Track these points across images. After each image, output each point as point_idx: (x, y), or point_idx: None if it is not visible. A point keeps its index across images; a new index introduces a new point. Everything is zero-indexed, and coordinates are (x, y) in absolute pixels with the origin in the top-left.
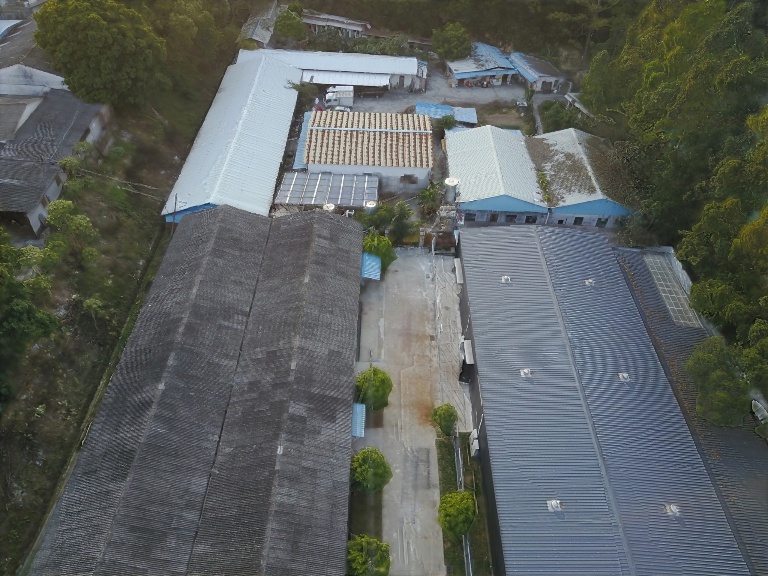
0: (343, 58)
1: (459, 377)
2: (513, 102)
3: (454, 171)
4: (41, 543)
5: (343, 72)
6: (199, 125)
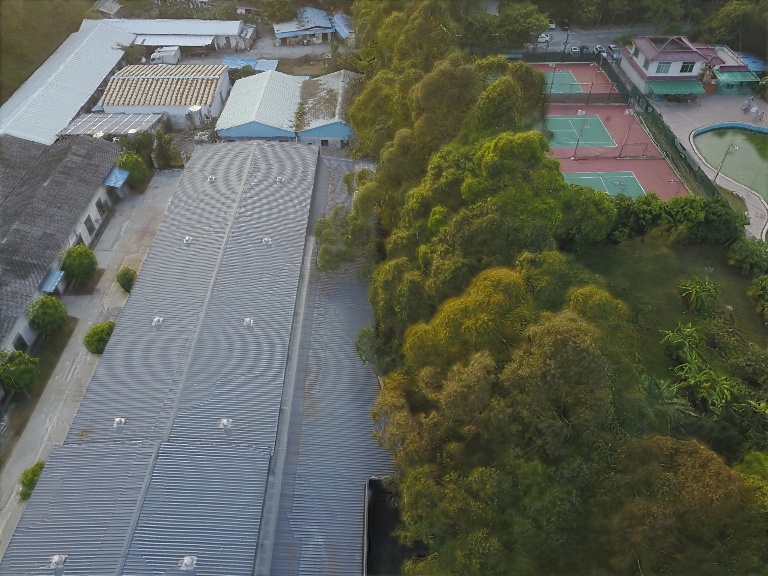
0: (174, 23)
1: None
2: (322, 56)
3: (227, 107)
4: None
5: (172, 35)
6: None
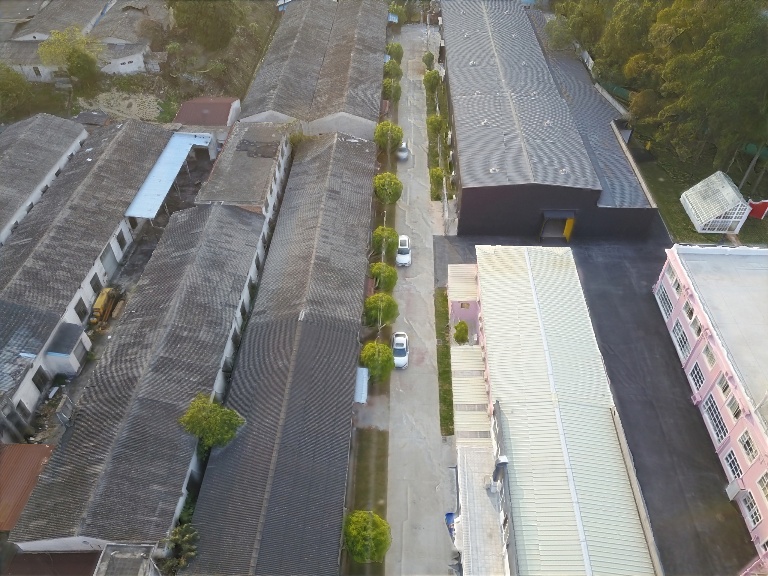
0: None
1: (438, 60)
2: None
3: None
4: None
5: None
6: None
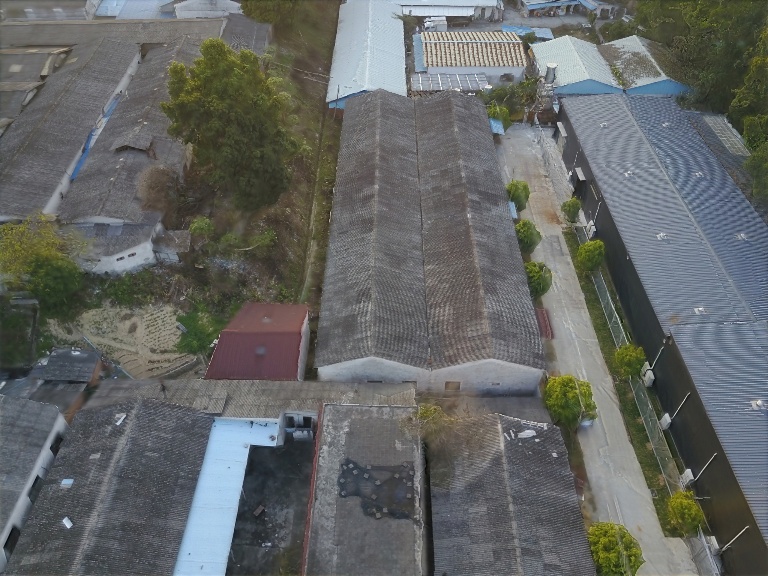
0: None
1: (572, 196)
2: (578, 25)
3: (544, 68)
4: (326, 266)
5: (435, 6)
6: (329, 47)
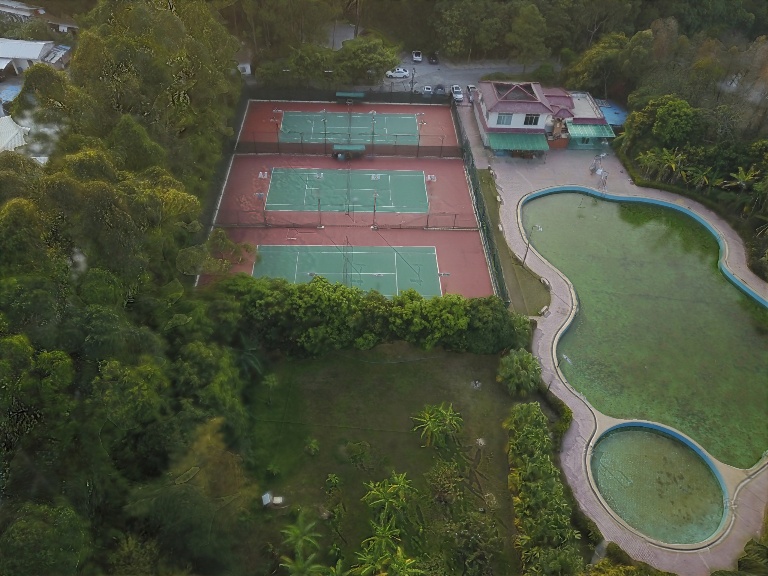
0: None
1: None
2: None
3: None
4: None
5: None
6: None
